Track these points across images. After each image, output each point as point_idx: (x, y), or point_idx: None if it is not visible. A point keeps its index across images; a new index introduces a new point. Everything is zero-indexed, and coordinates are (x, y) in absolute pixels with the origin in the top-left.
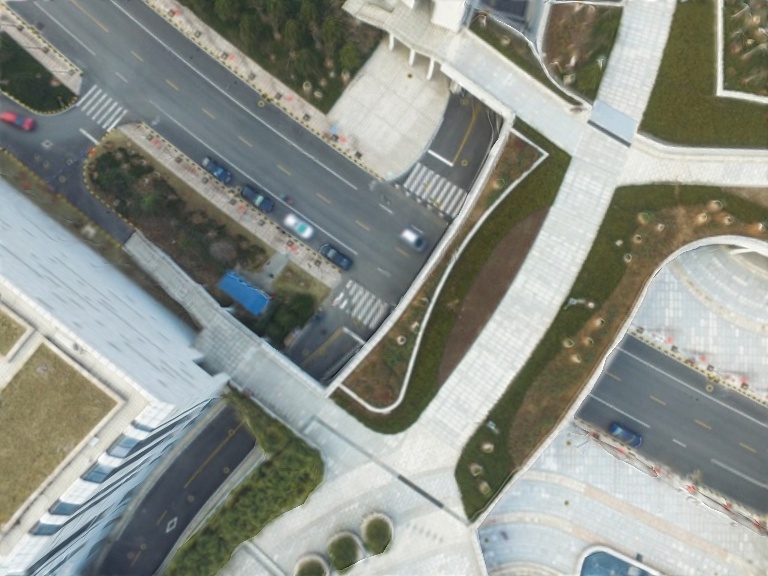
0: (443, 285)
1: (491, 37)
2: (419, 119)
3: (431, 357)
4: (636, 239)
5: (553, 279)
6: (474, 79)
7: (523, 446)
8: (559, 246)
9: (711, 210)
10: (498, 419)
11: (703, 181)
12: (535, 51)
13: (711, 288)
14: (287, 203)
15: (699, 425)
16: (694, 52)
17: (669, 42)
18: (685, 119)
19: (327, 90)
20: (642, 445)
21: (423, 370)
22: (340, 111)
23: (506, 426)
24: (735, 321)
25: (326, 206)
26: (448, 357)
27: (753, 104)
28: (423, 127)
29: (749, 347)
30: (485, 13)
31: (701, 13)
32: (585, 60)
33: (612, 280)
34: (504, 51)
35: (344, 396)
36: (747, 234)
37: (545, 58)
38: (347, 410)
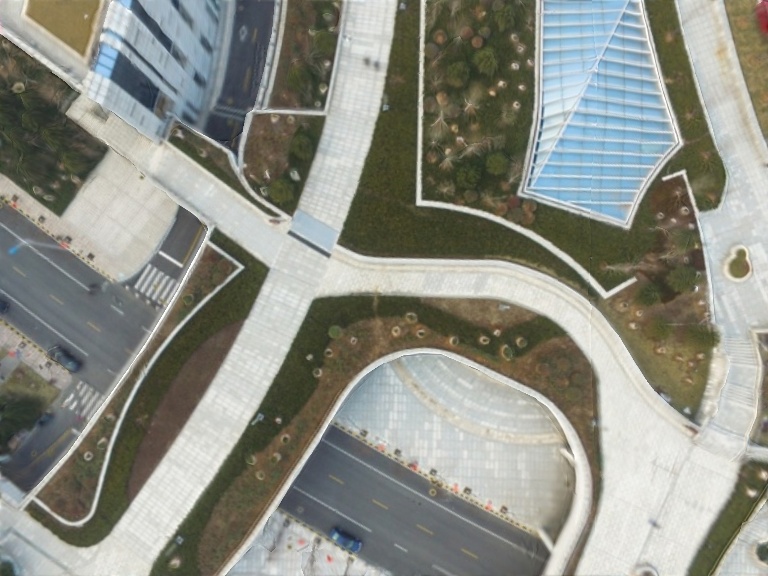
0: (132, 401)
1: (190, 149)
2: (151, 220)
3: (120, 472)
4: (326, 354)
5: (244, 393)
6: (176, 190)
7: (211, 561)
8: (252, 360)
9: (407, 322)
10: (186, 534)
11: (403, 291)
12: (234, 163)
13: (436, 391)
14: (23, 304)
15: (421, 530)
16: (395, 161)
17: (371, 151)
18: (385, 229)
19: (60, 193)
20: (362, 550)
21: (113, 485)
22: (74, 213)
23: (194, 541)
24: (459, 424)
25: (59, 307)
26: (137, 472)
27: (454, 213)
28: (155, 228)
29: (473, 451)
30: (182, 126)
31: (402, 122)
32: (280, 172)
33: (302, 395)
34: (203, 163)
35: (38, 509)
36: (442, 347)
37: (245, 169)
38: (42, 522)
